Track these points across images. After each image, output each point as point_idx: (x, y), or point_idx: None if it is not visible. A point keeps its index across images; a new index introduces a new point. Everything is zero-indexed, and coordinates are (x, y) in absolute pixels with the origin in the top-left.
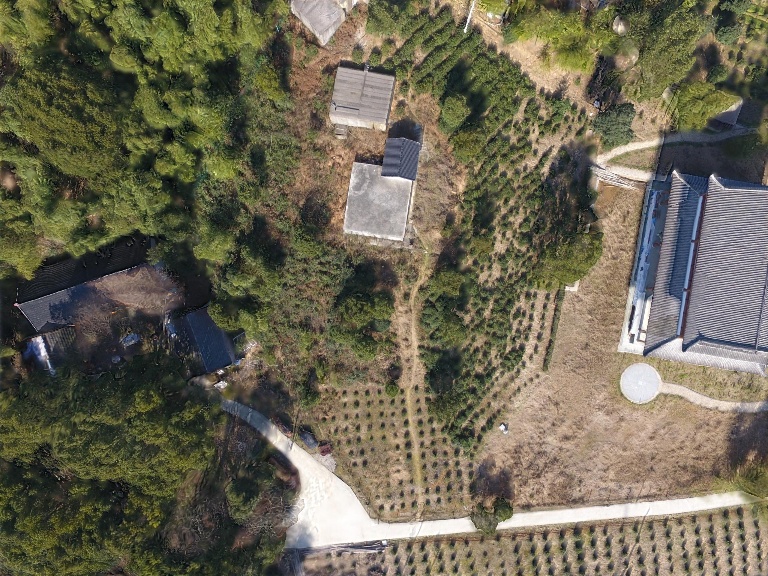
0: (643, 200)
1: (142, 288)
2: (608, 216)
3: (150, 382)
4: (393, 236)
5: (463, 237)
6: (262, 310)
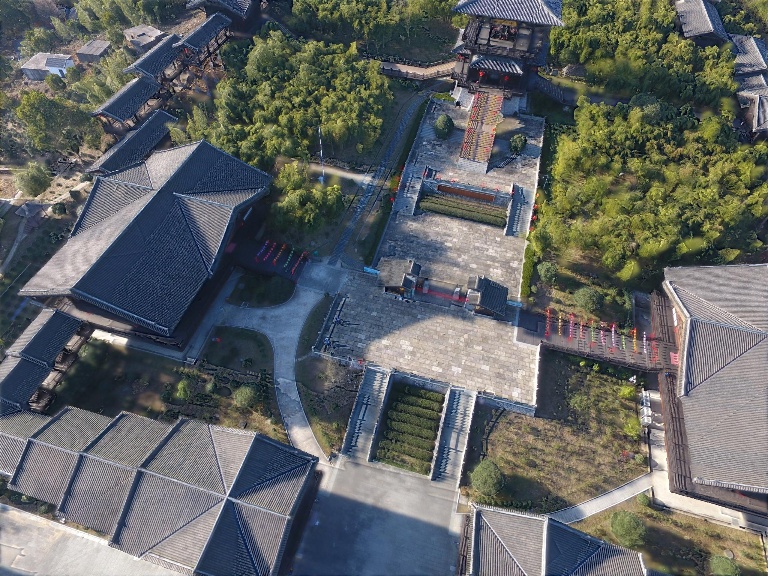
0: (5, 198)
1: (45, 3)
2: (5, 181)
3: (6, 11)
4: (24, 65)
5: (19, 104)
6: (31, 53)
